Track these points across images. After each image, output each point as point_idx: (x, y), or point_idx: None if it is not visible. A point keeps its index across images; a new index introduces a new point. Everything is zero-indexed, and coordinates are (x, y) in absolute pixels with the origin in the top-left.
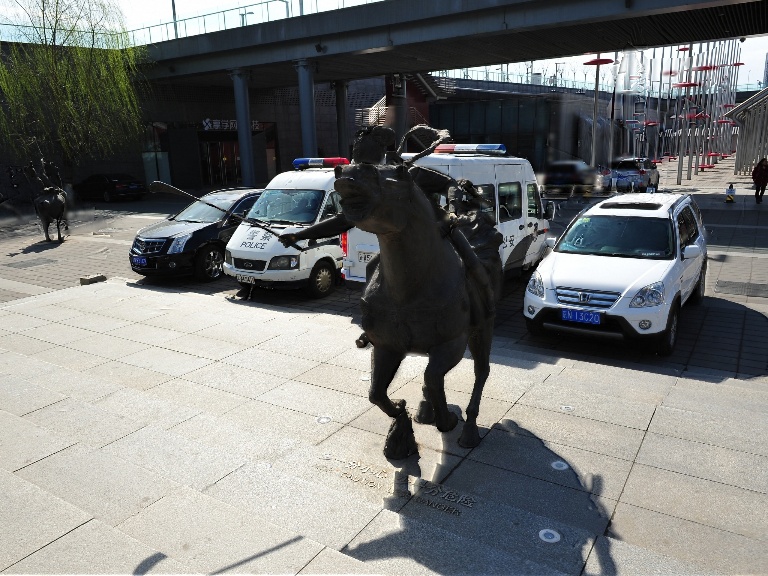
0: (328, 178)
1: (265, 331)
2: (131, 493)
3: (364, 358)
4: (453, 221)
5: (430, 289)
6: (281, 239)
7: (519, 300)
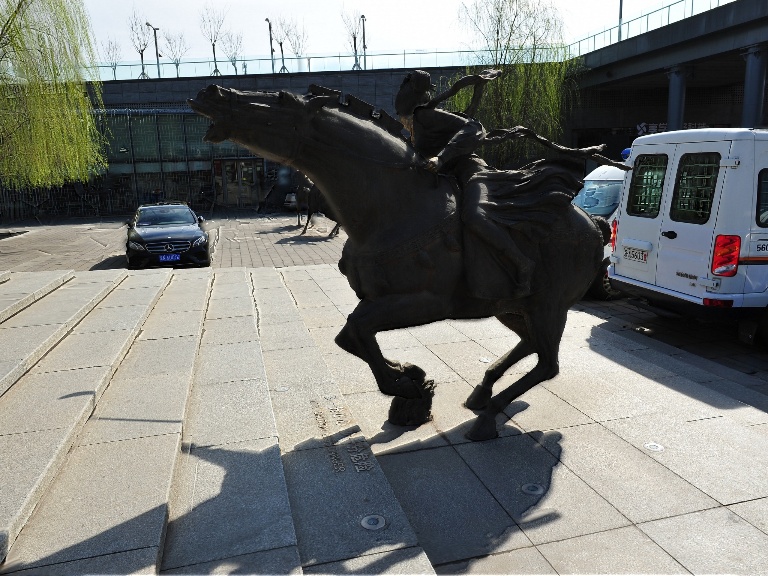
0: None
1: None
2: None
3: (514, 345)
4: (426, 165)
5: (376, 234)
6: None
7: None
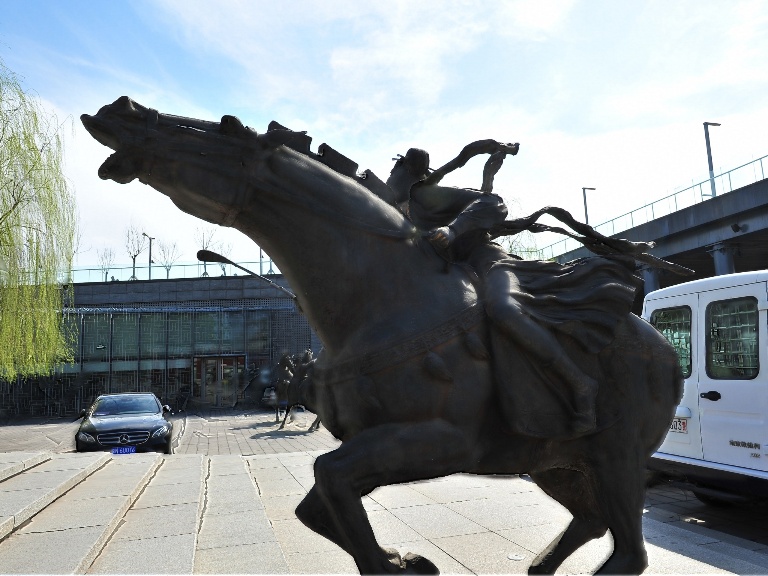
0: None
1: (490, 497)
2: (32, 570)
3: (550, 536)
4: (433, 234)
5: (361, 330)
6: (295, 301)
7: None
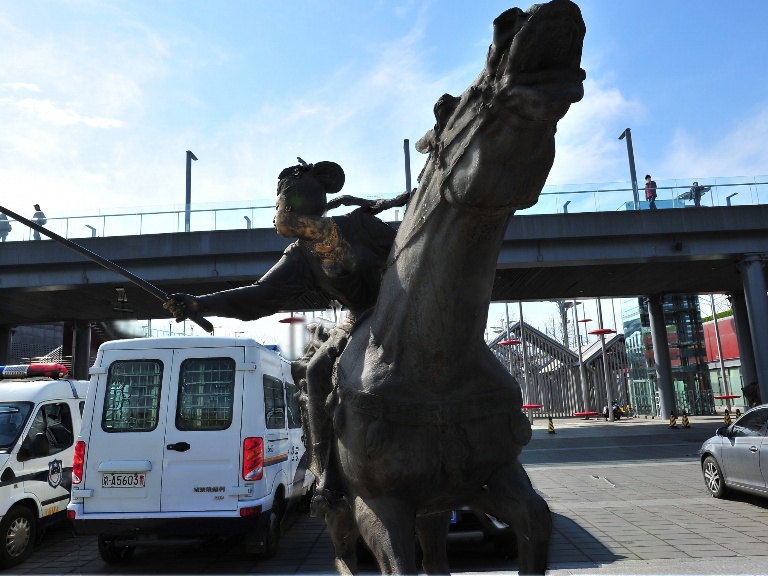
0: (38, 387)
1: None
2: None
3: None
4: None
5: (486, 362)
6: (174, 301)
7: (307, 531)
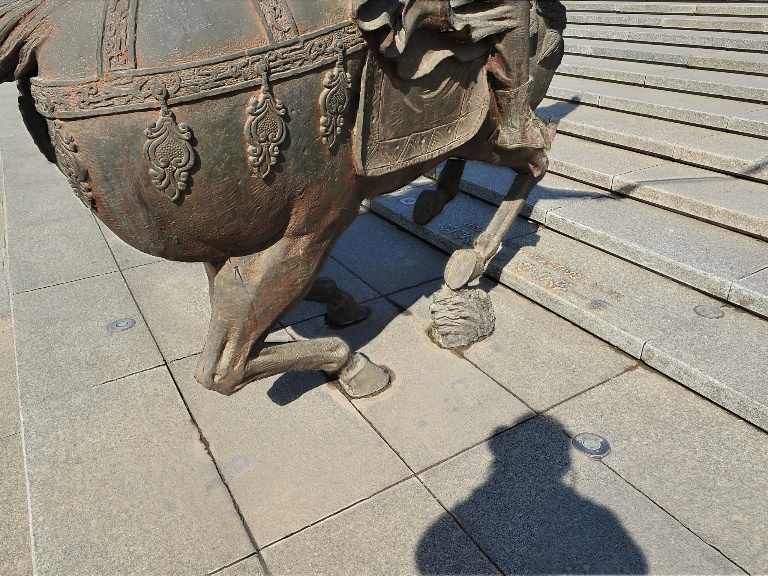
0: None
1: None
2: None
3: None
4: None
5: None
6: None
7: None
